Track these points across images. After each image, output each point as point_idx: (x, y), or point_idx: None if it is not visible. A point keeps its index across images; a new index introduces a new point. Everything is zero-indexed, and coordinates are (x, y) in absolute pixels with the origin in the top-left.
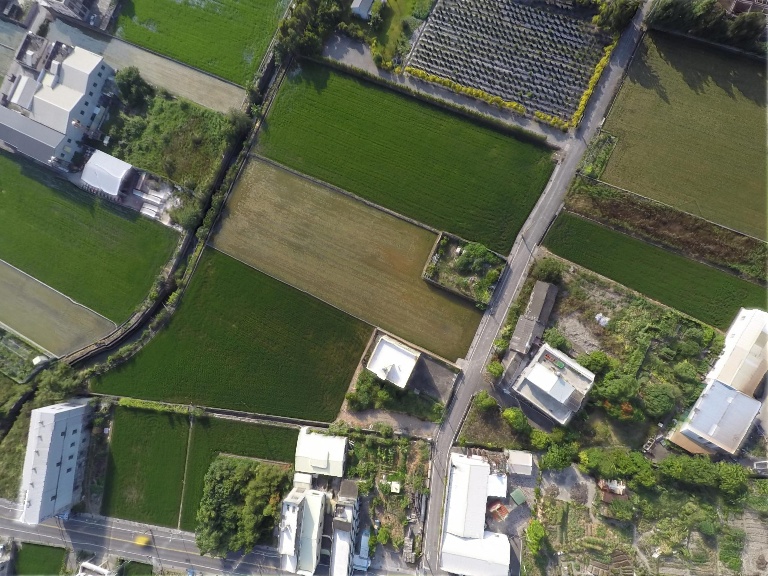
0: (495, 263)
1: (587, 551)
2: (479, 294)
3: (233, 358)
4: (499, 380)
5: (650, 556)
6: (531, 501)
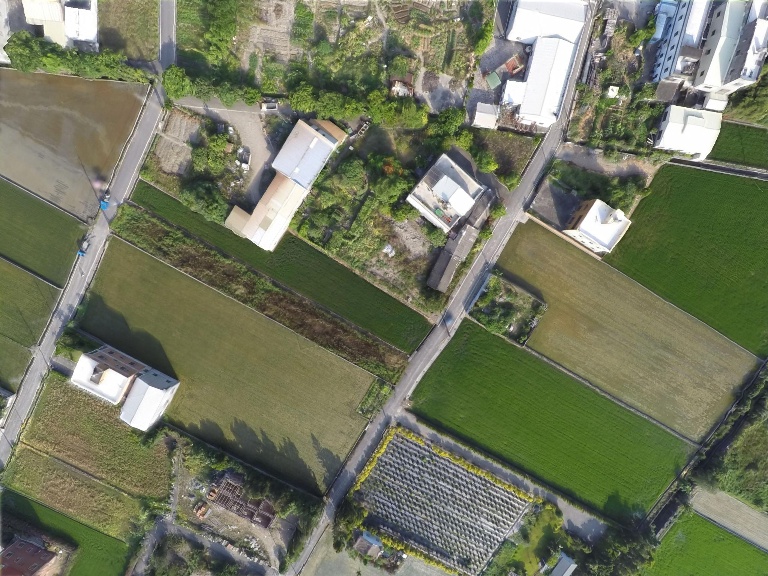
0: (478, 313)
1: (431, 22)
2: (497, 285)
3: (762, 240)
4: (494, 200)
5: (374, 17)
6: (477, 75)
